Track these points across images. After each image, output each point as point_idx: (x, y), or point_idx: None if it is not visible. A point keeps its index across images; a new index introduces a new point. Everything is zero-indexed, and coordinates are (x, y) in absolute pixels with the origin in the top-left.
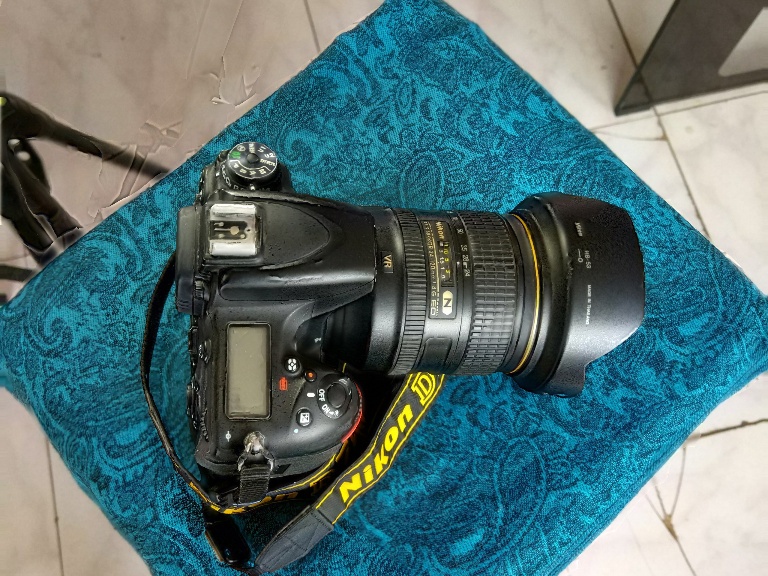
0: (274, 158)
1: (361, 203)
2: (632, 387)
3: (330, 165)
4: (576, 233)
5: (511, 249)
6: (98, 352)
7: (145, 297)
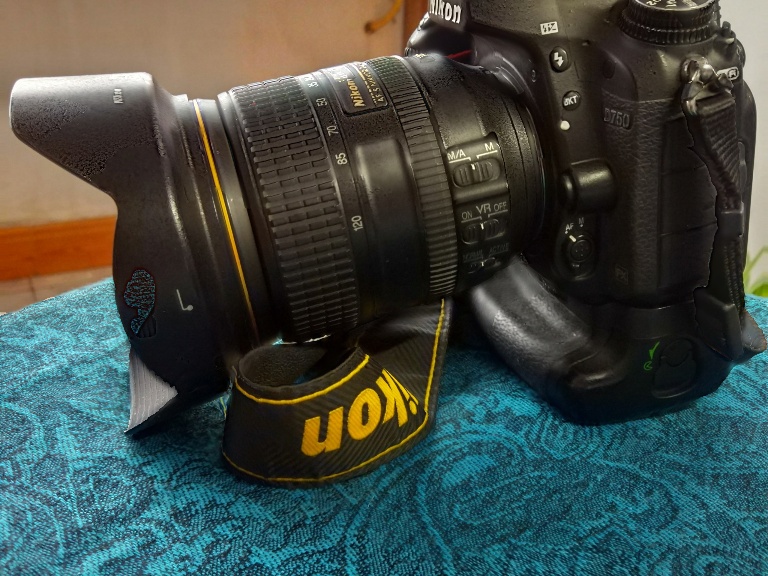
0: (645, 2)
1: (519, 517)
2: (9, 347)
3: (626, 571)
4: (125, 91)
5: (237, 101)
6: (762, 322)
7: (765, 366)
